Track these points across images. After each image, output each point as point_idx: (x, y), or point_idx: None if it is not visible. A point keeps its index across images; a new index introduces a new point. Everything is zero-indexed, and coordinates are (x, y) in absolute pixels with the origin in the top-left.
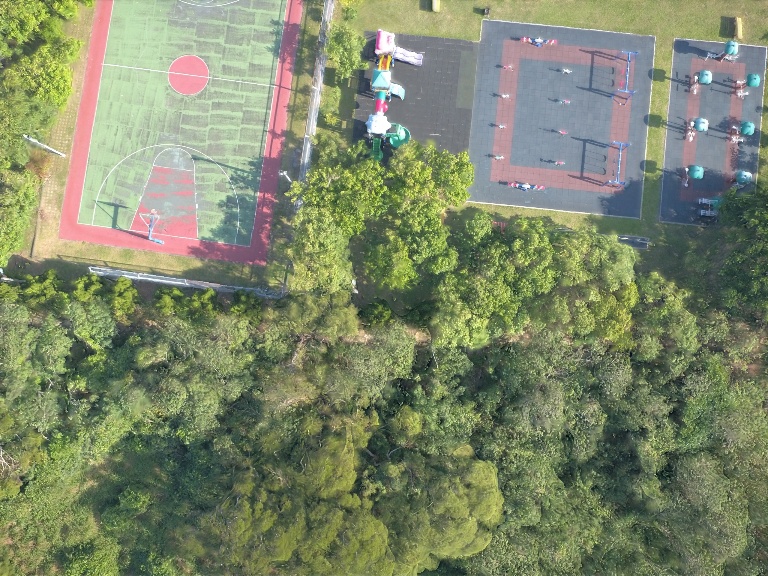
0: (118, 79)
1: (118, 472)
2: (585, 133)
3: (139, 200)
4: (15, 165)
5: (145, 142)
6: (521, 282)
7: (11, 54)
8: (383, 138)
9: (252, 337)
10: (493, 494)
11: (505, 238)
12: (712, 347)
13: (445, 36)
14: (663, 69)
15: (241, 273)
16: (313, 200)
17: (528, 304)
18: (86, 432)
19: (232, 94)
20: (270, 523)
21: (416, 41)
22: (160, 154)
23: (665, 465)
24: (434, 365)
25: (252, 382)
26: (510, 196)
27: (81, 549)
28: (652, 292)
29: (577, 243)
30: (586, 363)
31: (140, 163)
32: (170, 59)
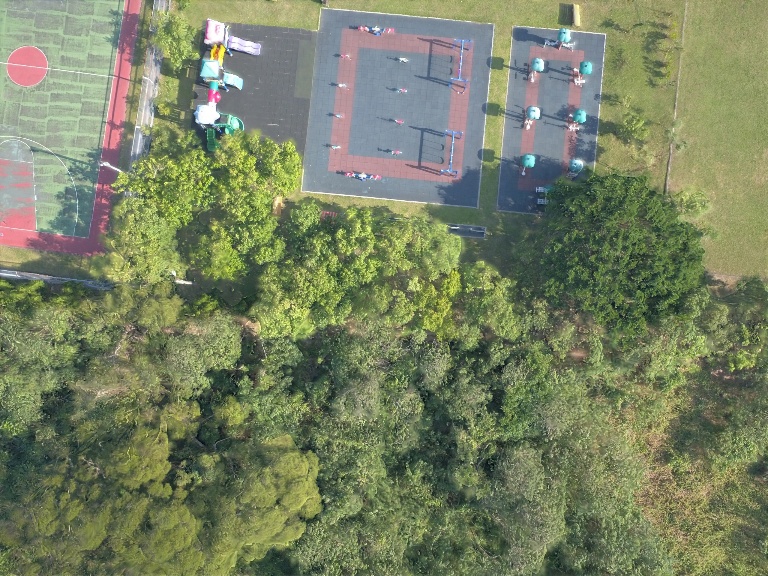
0: None
1: None
2: (423, 122)
3: None
4: None
5: None
6: (343, 272)
7: None
8: (216, 128)
9: (75, 328)
10: (302, 483)
11: (332, 228)
12: (533, 336)
13: (283, 25)
14: (501, 57)
15: (80, 265)
16: (139, 191)
17: (354, 294)
18: None
19: (71, 85)
20: (75, 513)
21: (255, 30)
22: None
23: (492, 453)
24: (263, 355)
25: (74, 373)
26: (347, 186)
27: None
28: (474, 281)
29: (398, 233)
30: (406, 352)
31: None
32: (9, 50)
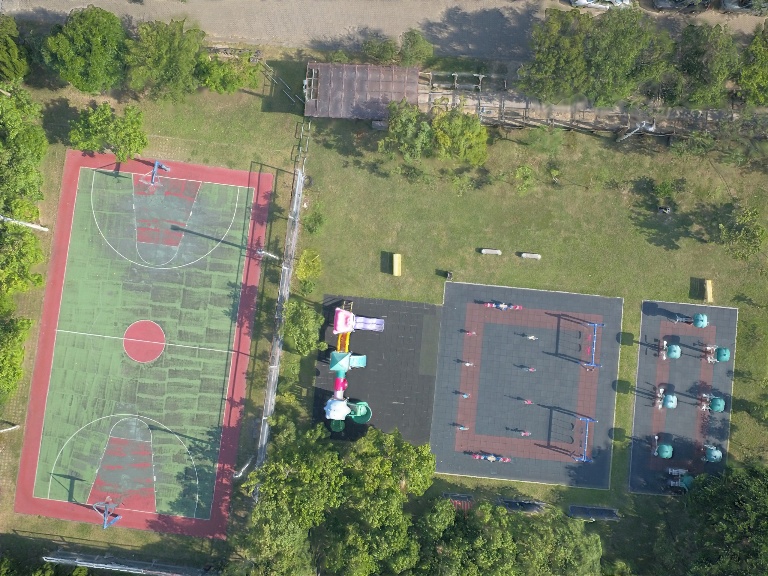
0: (72, 346)
1: None
2: (552, 400)
3: (95, 473)
4: None
5: (101, 412)
6: None
7: None
8: None
9: None
10: None
11: (468, 528)
12: None
13: (407, 299)
14: (631, 332)
15: (201, 548)
16: (271, 493)
17: None
18: None
19: (189, 361)
20: None
21: (377, 304)
22: (116, 424)
23: None
24: None
25: None
26: (475, 467)
27: None
28: None
29: (541, 543)
30: None
31: (96, 434)
32: (125, 325)
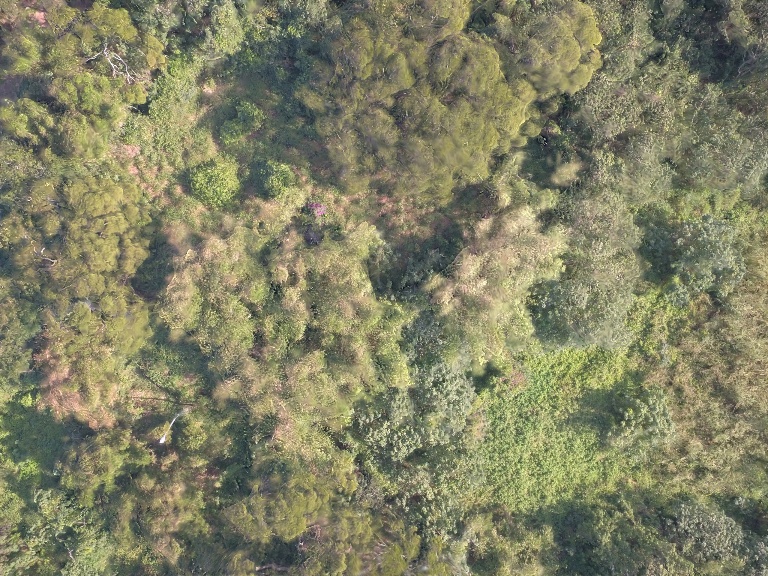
0: None
1: (231, 96)
2: None
3: None
4: None
5: None
6: None
7: None
8: None
9: None
10: (593, 21)
11: None
12: None
13: None
14: None
15: None
16: None
17: None
18: (207, 26)
19: None
20: (391, 50)
21: None
22: None
23: (746, 25)
24: None
25: None
26: None
27: (203, 166)
28: None
29: None
30: None
31: None
32: None
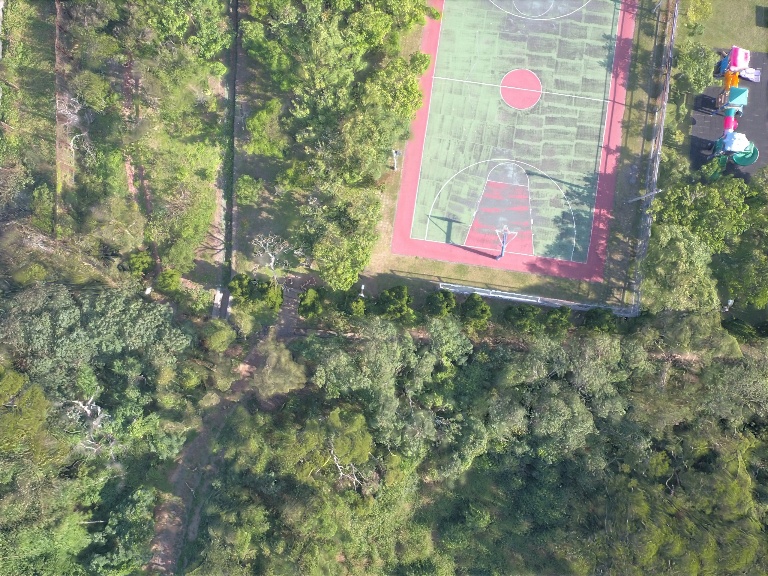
0: (449, 92)
1: (454, 490)
2: None
3: (473, 215)
4: None
5: (478, 156)
6: None
7: (363, 67)
8: (731, 155)
9: (624, 357)
10: None
11: None
12: None
13: None
14: None
15: (578, 290)
16: (676, 218)
17: None
18: (455, 451)
19: (566, 109)
20: (684, 548)
21: (752, 57)
22: (494, 169)
23: None
24: None
25: (627, 403)
26: None
27: (420, 568)
28: None
29: None
30: None
31: (474, 178)
32: (502, 73)
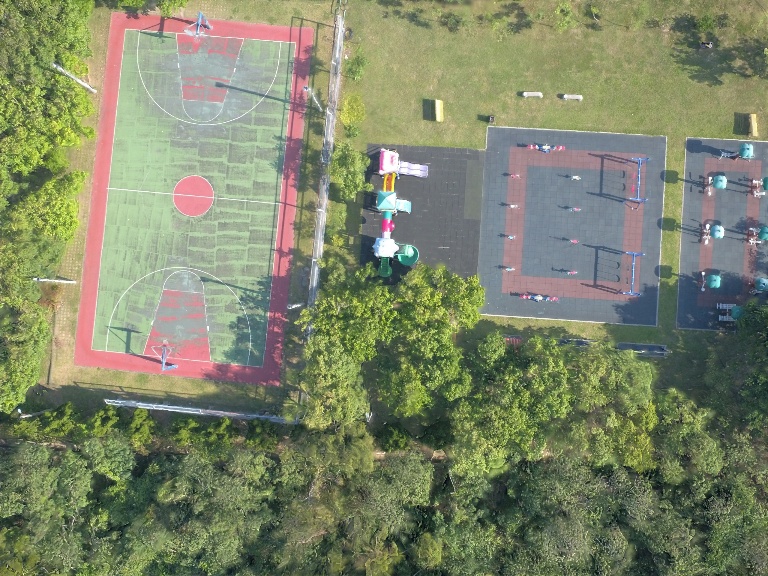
0: (124, 203)
1: None
2: (597, 240)
3: (151, 324)
4: (27, 299)
5: (154, 266)
6: (536, 408)
7: (17, 191)
8: (391, 257)
9: (268, 471)
10: None
11: (518, 359)
12: (733, 467)
13: (450, 145)
14: (676, 170)
15: (255, 394)
16: (323, 329)
17: (544, 426)
18: (110, 569)
19: (238, 214)
20: None
21: (421, 152)
22: (169, 277)
23: None
24: (451, 488)
25: (270, 517)
26: (522, 307)
27: None
28: (670, 413)
29: (592, 367)
30: (605, 488)
31: (150, 287)
32: (174, 180)
